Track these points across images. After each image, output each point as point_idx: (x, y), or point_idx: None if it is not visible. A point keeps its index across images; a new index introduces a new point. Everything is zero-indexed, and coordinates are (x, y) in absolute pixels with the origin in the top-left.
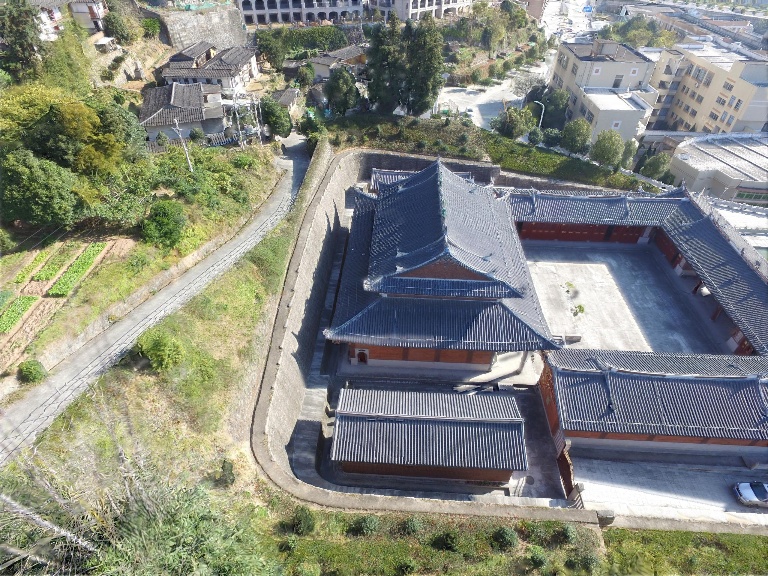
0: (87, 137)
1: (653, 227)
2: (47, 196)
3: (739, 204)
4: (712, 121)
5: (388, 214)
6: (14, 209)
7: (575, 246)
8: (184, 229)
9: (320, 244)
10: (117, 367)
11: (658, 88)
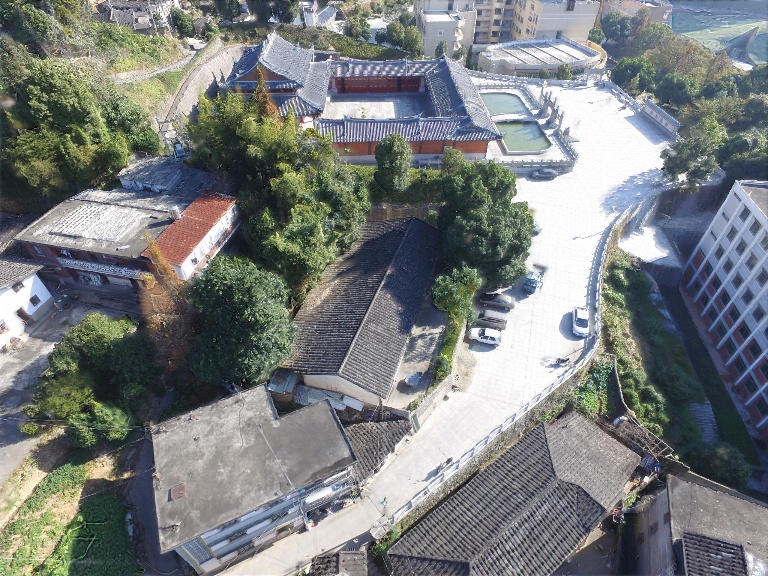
0: (61, 1)
1: (424, 79)
2: (44, 27)
3: (505, 76)
4: (527, 35)
5: (243, 61)
6: (27, 34)
7: (379, 95)
8: (118, 58)
9: (206, 85)
10: None
11: (495, 14)
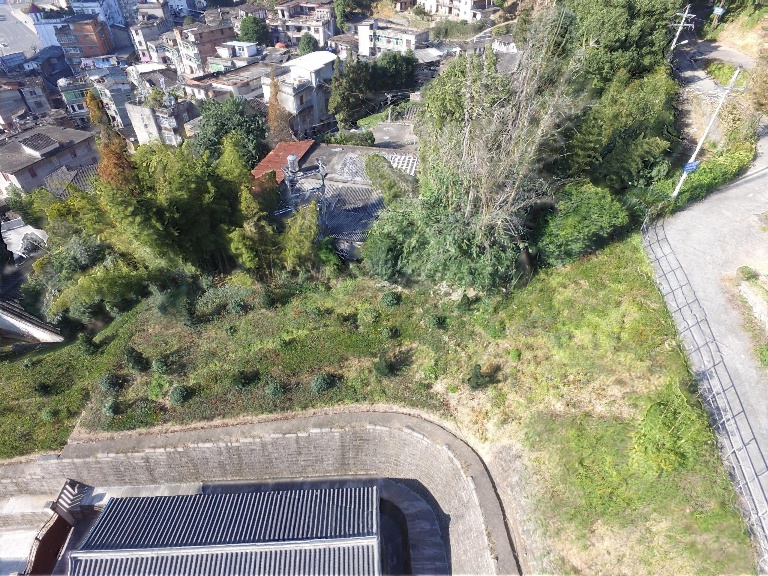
0: None
1: None
2: None
3: None
4: None
5: None
6: None
7: None
8: None
9: None
10: (688, 387)
11: None
